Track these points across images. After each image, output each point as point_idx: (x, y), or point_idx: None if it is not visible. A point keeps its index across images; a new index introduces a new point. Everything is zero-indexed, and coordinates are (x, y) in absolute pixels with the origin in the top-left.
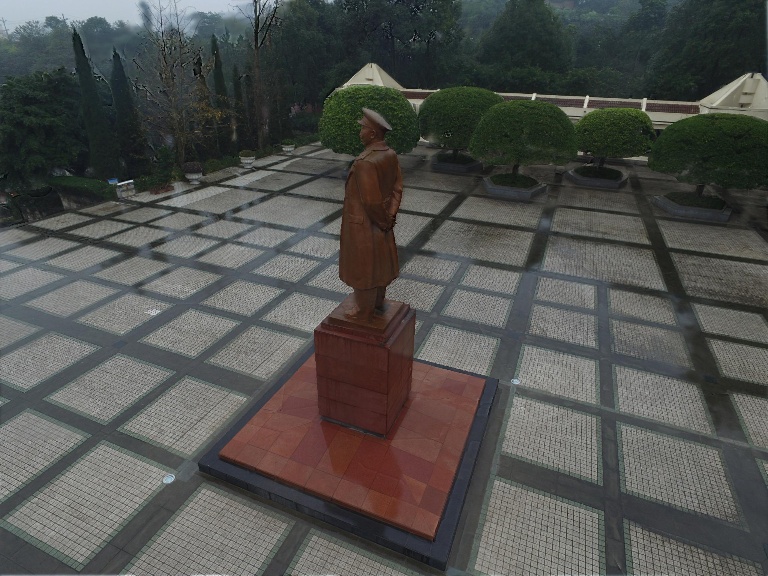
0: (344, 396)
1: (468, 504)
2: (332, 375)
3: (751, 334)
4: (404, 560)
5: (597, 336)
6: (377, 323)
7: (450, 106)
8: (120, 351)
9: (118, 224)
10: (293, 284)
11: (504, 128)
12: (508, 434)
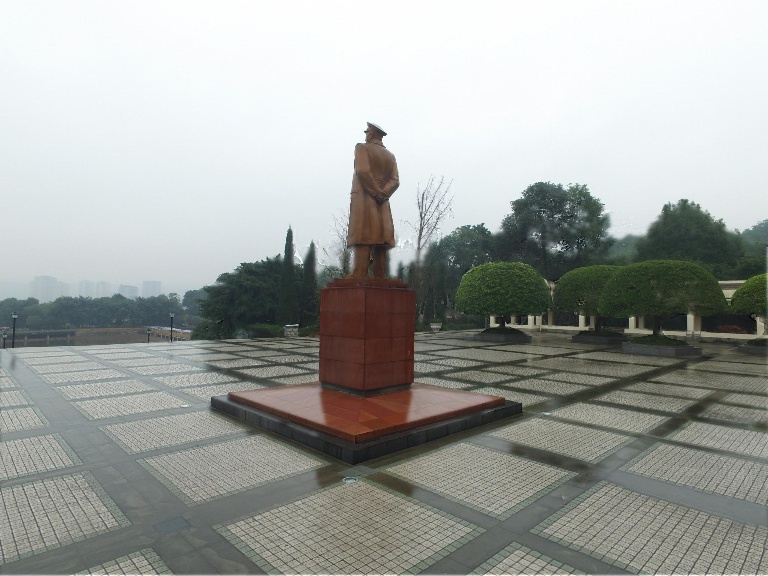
0: (336, 352)
1: (418, 447)
2: (329, 331)
3: None
4: (322, 455)
5: (685, 408)
6: None
7: (582, 278)
8: (216, 371)
9: (273, 342)
10: None
11: (629, 281)
12: (505, 429)
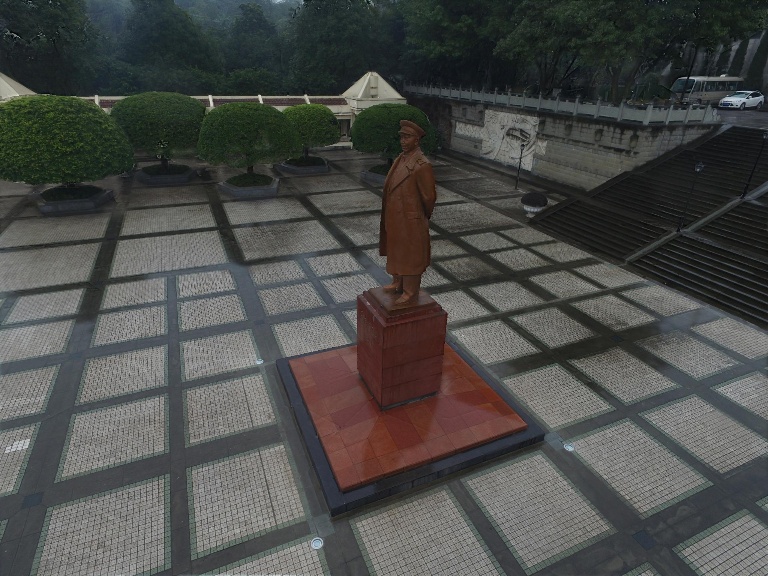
0: (407, 376)
1: None
2: (398, 362)
3: (500, 244)
4: (523, 451)
5: (442, 275)
6: (425, 300)
7: (154, 114)
8: (48, 505)
9: None
10: (166, 336)
11: (239, 131)
12: (476, 354)
